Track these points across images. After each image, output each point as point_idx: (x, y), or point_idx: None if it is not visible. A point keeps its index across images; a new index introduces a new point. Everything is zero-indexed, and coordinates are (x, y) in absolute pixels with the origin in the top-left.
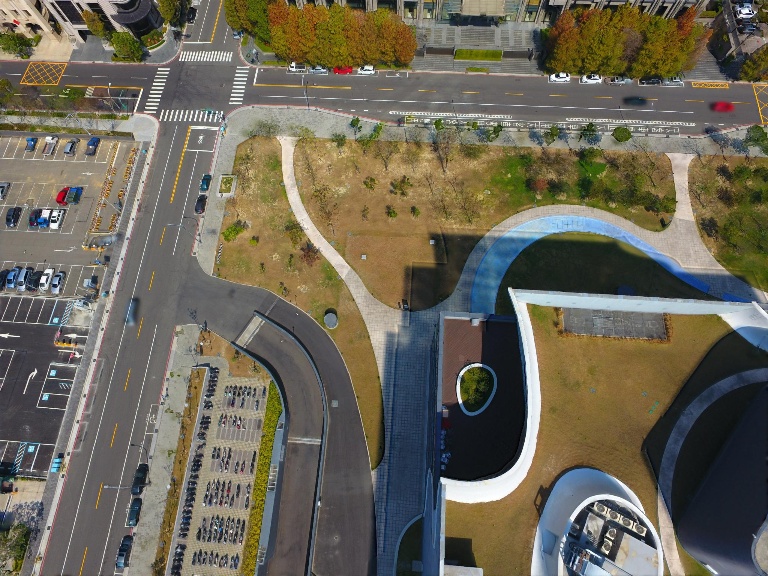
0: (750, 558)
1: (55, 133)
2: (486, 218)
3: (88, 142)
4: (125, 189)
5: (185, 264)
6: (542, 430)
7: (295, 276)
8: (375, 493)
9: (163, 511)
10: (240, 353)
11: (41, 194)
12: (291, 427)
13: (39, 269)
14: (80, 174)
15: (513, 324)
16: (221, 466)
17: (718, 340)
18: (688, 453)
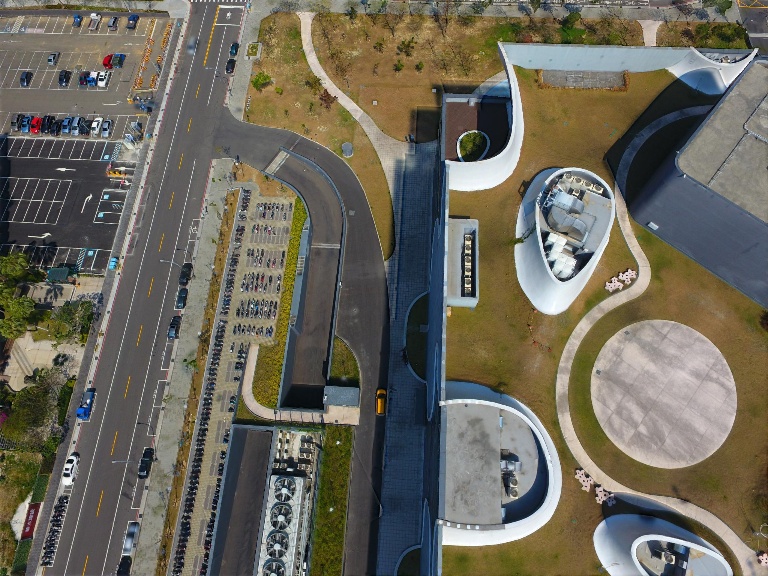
0: (674, 166)
1: (99, 11)
2: (481, 72)
3: (129, 17)
4: (163, 55)
5: (218, 112)
6: (525, 146)
7: (315, 119)
8: (388, 277)
9: (206, 297)
10: (269, 178)
11: (88, 61)
12: (314, 236)
13: (90, 119)
14: (122, 45)
15: (503, 104)
16: (255, 261)
17: (665, 87)
18: (639, 161)
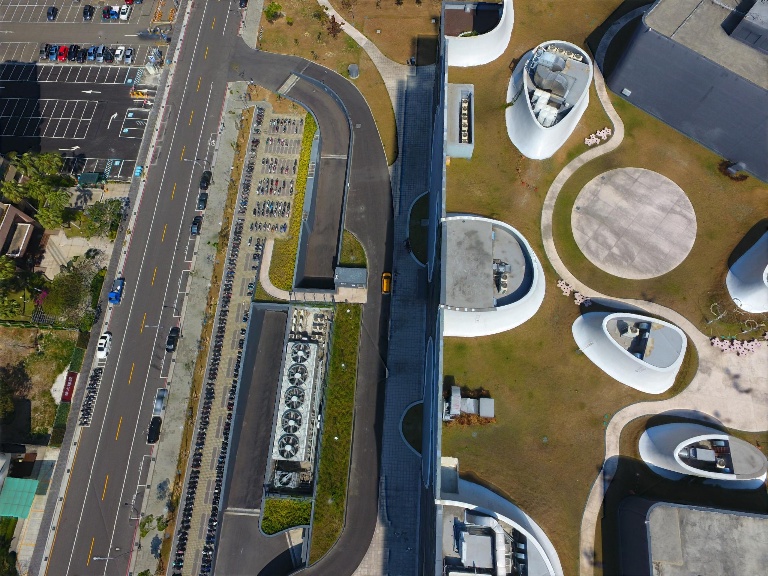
0: (641, 23)
1: None
2: None
3: None
4: None
5: (233, 42)
6: (515, 31)
7: (323, 46)
8: (391, 180)
9: (225, 200)
10: (281, 97)
11: None
12: (323, 148)
13: (113, 48)
14: None
15: (496, 11)
16: (270, 168)
17: None
18: (616, 44)
